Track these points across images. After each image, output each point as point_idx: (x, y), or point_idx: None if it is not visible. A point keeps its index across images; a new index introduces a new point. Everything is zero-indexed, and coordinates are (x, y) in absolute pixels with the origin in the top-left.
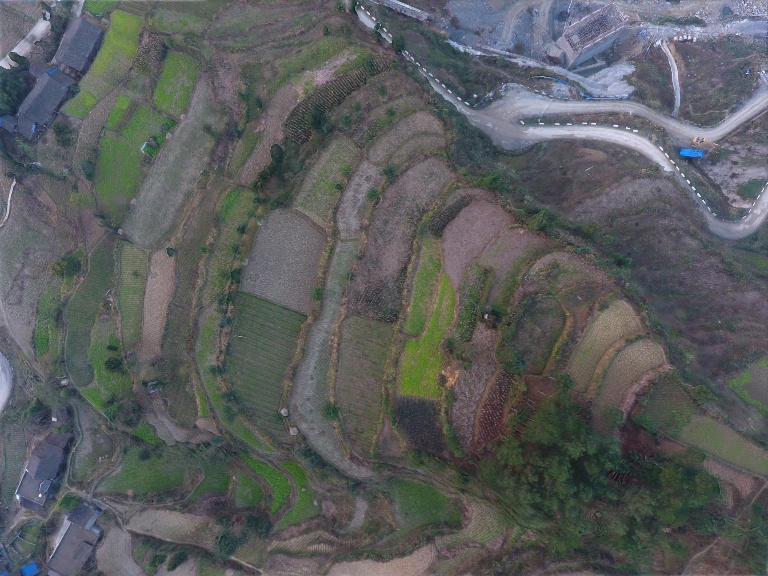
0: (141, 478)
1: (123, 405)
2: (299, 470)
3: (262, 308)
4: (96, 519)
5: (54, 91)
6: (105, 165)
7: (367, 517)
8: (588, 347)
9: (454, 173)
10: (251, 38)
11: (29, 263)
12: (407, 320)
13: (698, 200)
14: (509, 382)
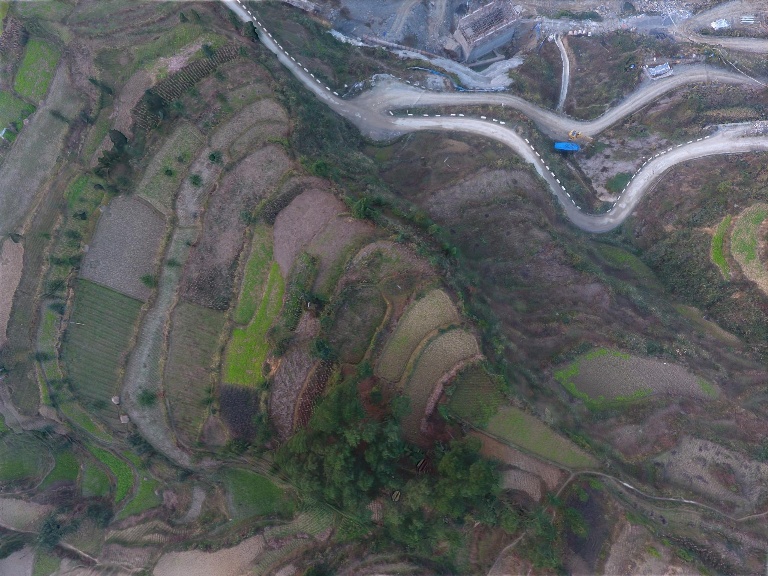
0: None
1: None
2: None
3: (101, 295)
4: None
5: None
6: None
7: (204, 507)
8: (403, 336)
9: (293, 161)
10: (112, 24)
11: None
12: (237, 308)
13: (563, 193)
14: (327, 371)
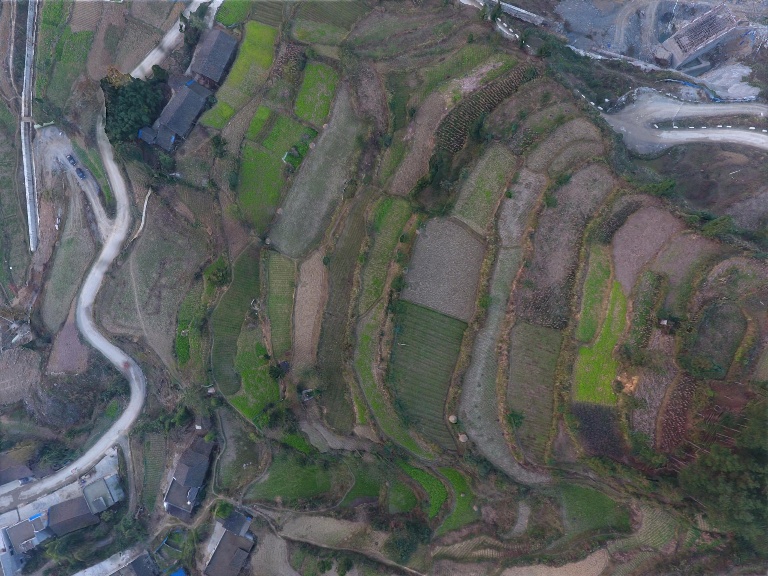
0: (289, 485)
1: (276, 413)
2: (457, 476)
3: (423, 316)
4: (249, 526)
5: (193, 102)
6: (247, 175)
7: (531, 522)
8: None
9: (617, 179)
10: (391, 47)
11: (166, 273)
12: (578, 327)
13: None
14: (692, 388)
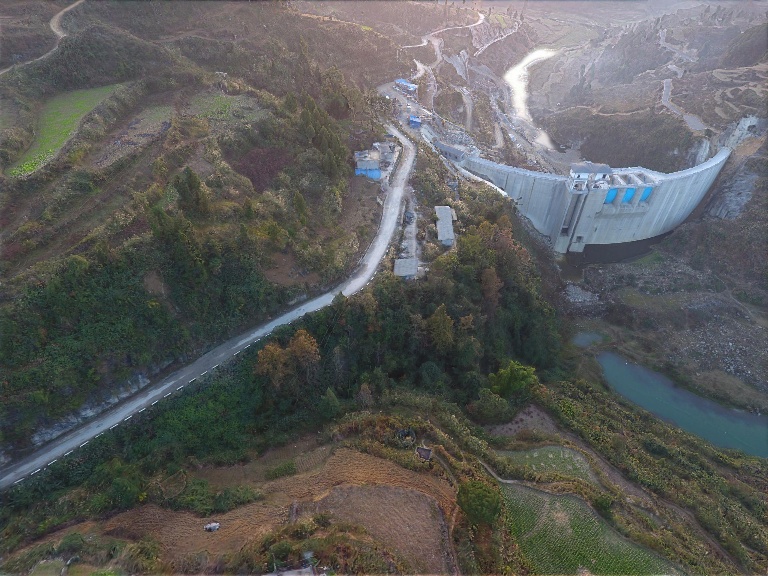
0: None
1: None
2: None
3: None
4: None
5: None
6: None
7: None
8: None
9: None
10: None
11: None
12: None
13: None
14: None
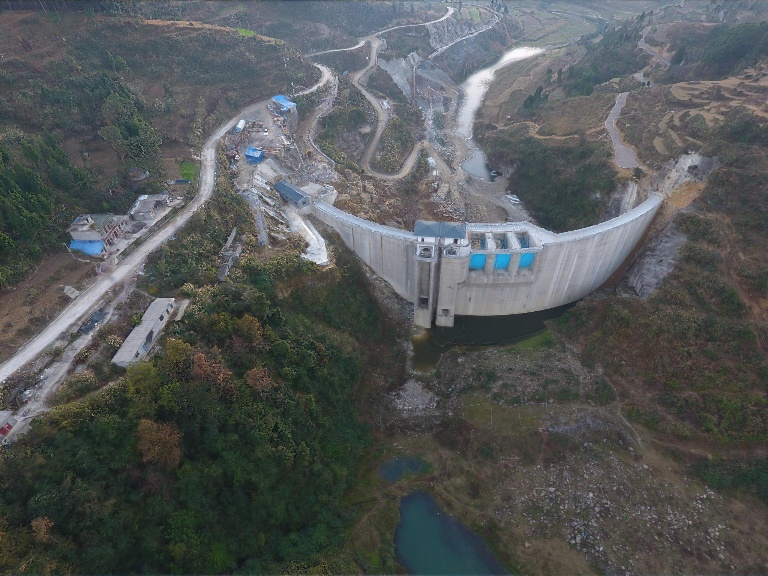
0: None
1: None
2: None
3: None
4: None
5: None
6: None
7: None
8: None
9: None
10: None
11: None
12: None
13: None
14: None
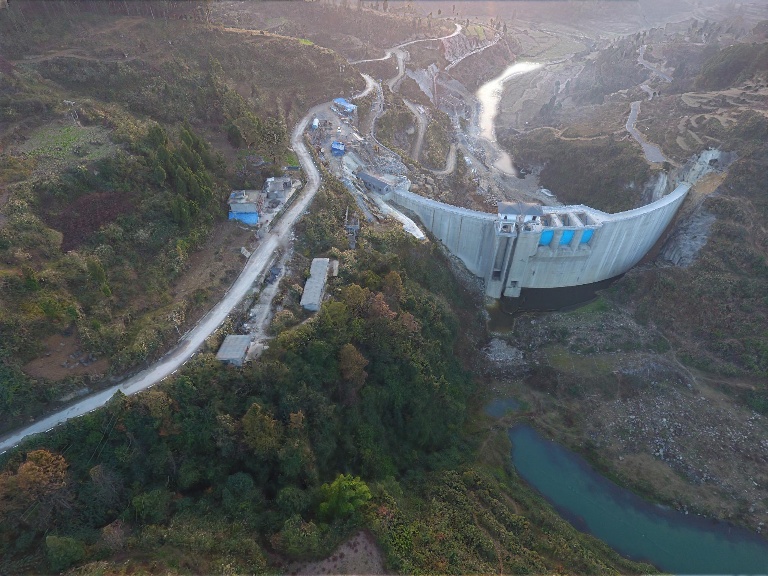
0: None
1: None
2: None
3: None
4: None
5: None
6: None
7: None
8: None
9: None
10: None
11: None
12: None
13: None
14: None
